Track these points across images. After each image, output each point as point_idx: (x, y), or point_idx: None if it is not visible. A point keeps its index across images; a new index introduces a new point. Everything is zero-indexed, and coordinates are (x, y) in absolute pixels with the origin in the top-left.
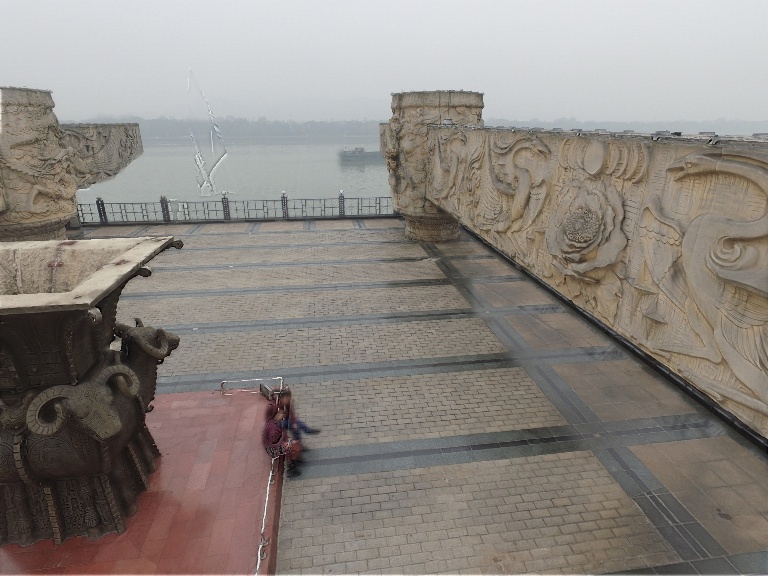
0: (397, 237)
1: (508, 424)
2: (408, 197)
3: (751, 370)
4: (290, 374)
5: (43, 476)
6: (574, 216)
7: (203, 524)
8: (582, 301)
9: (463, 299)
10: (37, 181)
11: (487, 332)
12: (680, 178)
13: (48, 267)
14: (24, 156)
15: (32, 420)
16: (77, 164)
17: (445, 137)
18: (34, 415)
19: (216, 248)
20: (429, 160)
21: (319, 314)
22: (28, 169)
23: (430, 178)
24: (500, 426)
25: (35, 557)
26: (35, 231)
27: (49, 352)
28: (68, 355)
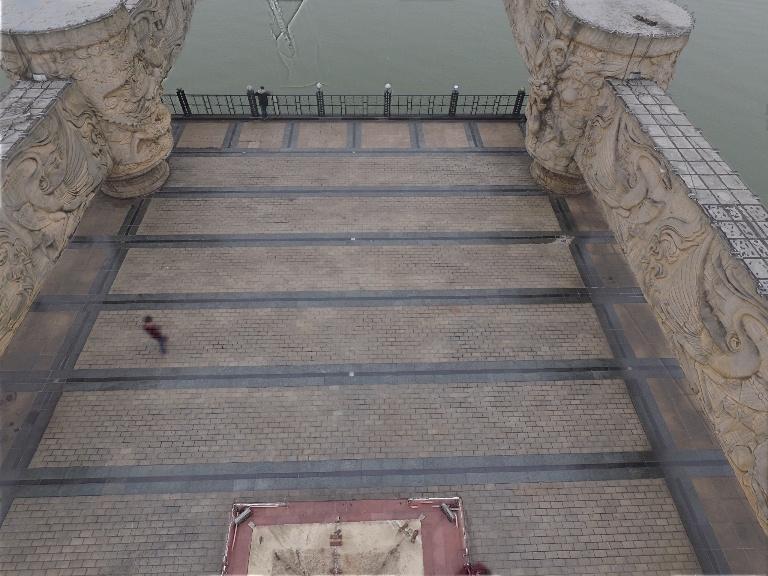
0: (521, 177)
1: (652, 570)
2: (551, 151)
3: None
4: (455, 468)
5: None
6: None
7: None
8: None
9: (604, 338)
10: (136, 129)
11: (631, 410)
12: None
13: (331, 574)
14: (118, 103)
15: None
16: (153, 58)
17: (634, 137)
18: None
19: (326, 191)
20: (594, 124)
21: (463, 356)
22: (125, 118)
23: (589, 151)
24: (645, 572)
25: None
26: (141, 174)
27: None
28: None
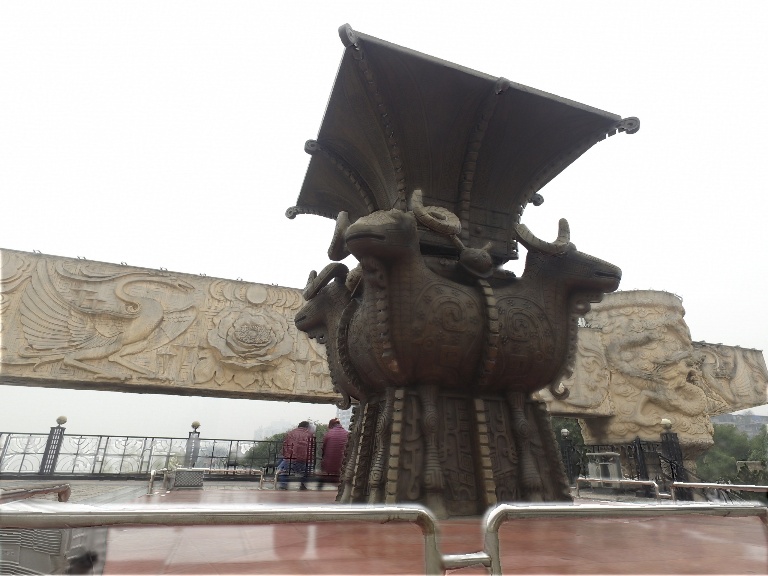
0: None
1: None
2: None
3: None
4: None
5: None
6: (245, 329)
7: None
8: (255, 387)
9: None
10: None
11: None
12: None
13: None
14: None
15: None
16: None
17: None
18: None
19: None
20: None
21: None
22: None
23: None
24: None
25: None
26: None
27: None
28: None
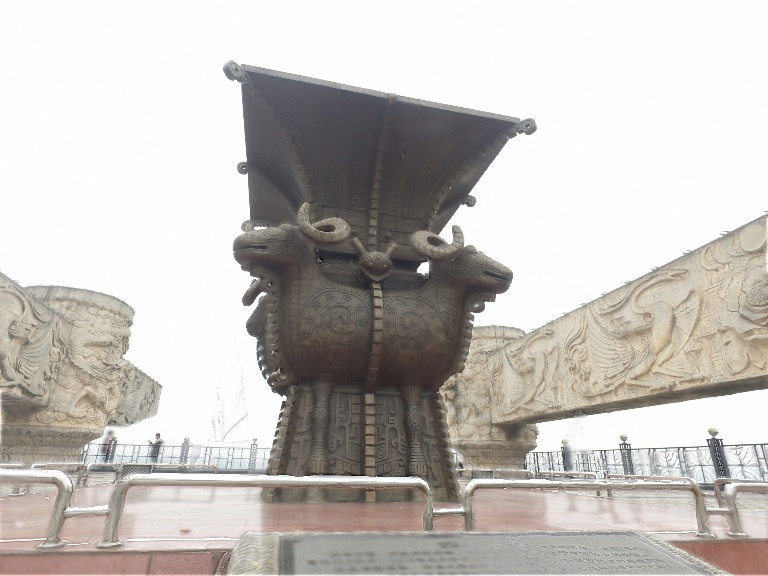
0: None
1: None
2: (472, 425)
3: None
4: None
5: (384, 357)
6: (755, 288)
7: (575, 503)
8: None
9: None
10: (91, 382)
11: (665, 493)
12: None
13: None
14: (91, 356)
15: (424, 241)
16: None
17: (518, 347)
18: (424, 239)
19: None
20: (493, 382)
21: None
22: (89, 369)
23: (499, 397)
24: None
25: (348, 505)
26: (56, 441)
27: (409, 218)
28: (431, 221)
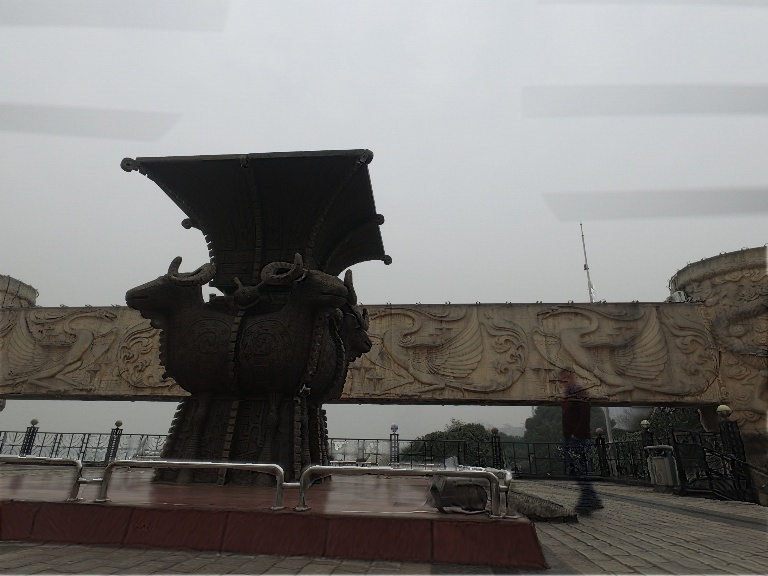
0: None
1: None
2: None
3: (428, 376)
4: None
5: None
6: None
7: None
8: None
9: None
10: None
11: None
12: (375, 318)
13: None
14: None
15: None
16: None
17: (53, 316)
18: None
19: None
20: None
21: None
22: None
23: None
24: None
25: None
26: None
27: None
28: None
